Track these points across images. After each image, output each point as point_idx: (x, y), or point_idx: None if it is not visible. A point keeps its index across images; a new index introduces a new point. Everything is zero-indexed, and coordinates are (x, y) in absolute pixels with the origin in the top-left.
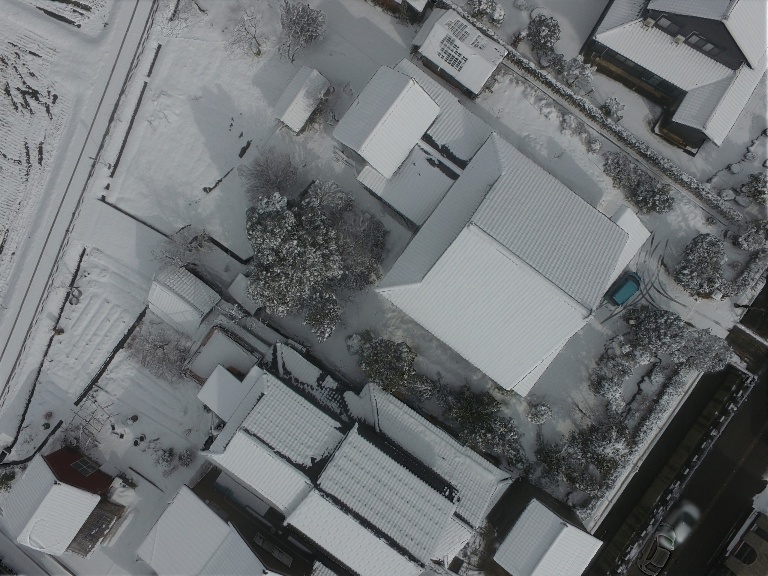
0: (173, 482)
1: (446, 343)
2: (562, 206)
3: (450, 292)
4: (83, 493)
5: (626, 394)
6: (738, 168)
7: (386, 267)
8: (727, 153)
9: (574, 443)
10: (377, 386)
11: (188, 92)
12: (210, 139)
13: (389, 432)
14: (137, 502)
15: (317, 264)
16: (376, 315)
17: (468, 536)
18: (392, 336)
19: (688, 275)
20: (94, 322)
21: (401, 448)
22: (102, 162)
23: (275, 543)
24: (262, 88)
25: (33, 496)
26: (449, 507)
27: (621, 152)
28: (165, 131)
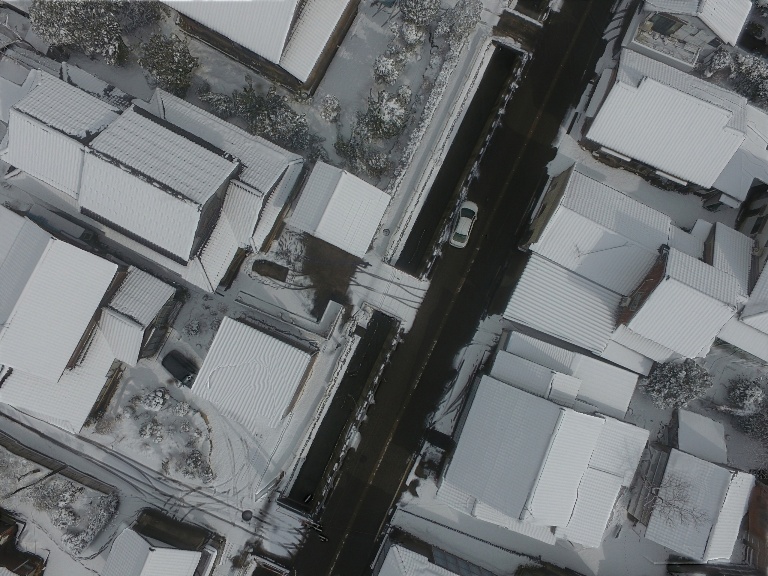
0: None
1: (214, 29)
2: None
3: None
4: None
5: (413, 85)
6: None
7: None
8: None
9: (360, 121)
10: (164, 91)
11: None
12: None
13: (175, 123)
14: None
15: None
16: None
17: (260, 204)
18: None
19: None
20: None
21: None
22: None
23: (86, 250)
24: None
25: None
26: (228, 165)
27: None
28: None
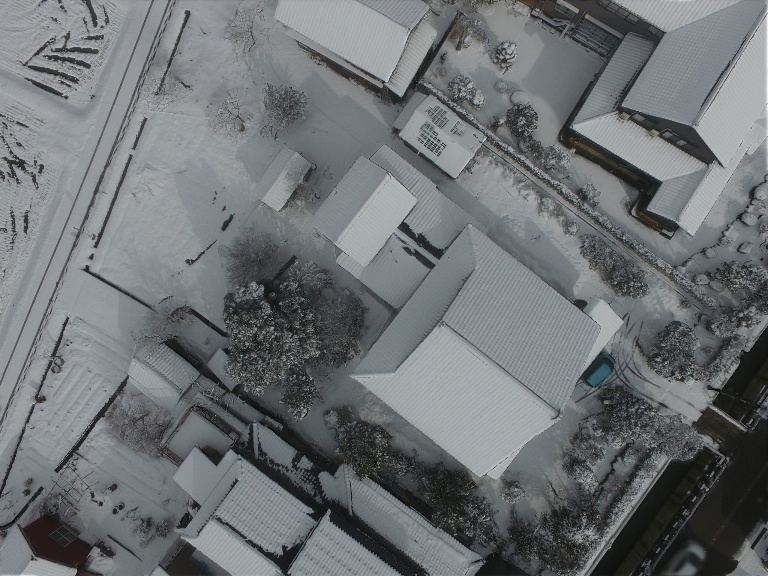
0: (150, 552)
1: (419, 429)
2: (535, 299)
3: (423, 384)
4: (60, 567)
5: (599, 473)
6: (713, 253)
7: (364, 344)
8: (703, 236)
9: (546, 525)
10: None
11: (172, 165)
12: (193, 212)
13: (362, 515)
14: (115, 570)
15: (294, 348)
16: (354, 390)
17: None
18: (369, 412)
19: (660, 363)
20: (76, 390)
21: (374, 531)
22: (86, 233)
23: None
24: (245, 163)
25: (10, 571)
26: None
27: (597, 236)
28: (149, 203)
